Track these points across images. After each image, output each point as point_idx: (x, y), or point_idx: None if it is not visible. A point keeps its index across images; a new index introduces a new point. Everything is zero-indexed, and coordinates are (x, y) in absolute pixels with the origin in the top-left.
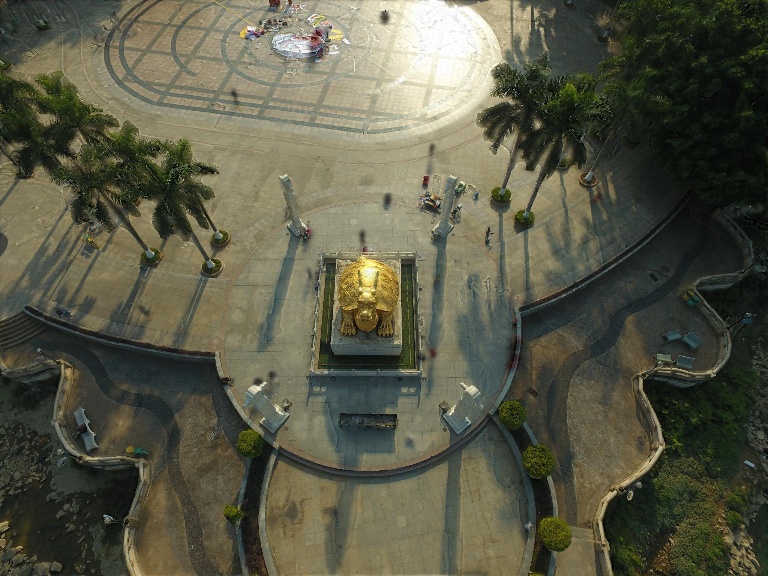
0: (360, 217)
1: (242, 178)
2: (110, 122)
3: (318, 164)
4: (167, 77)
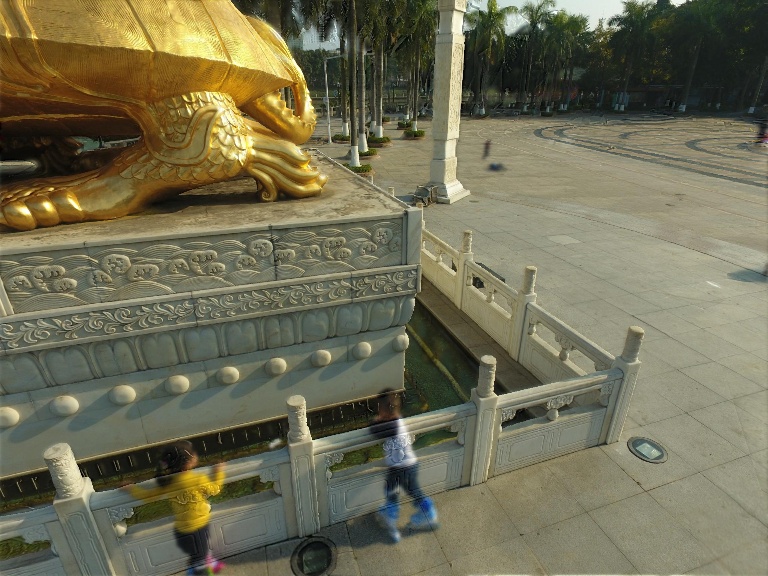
0: (600, 244)
1: (503, 167)
2: (412, 5)
3: (661, 196)
4: (591, 135)
